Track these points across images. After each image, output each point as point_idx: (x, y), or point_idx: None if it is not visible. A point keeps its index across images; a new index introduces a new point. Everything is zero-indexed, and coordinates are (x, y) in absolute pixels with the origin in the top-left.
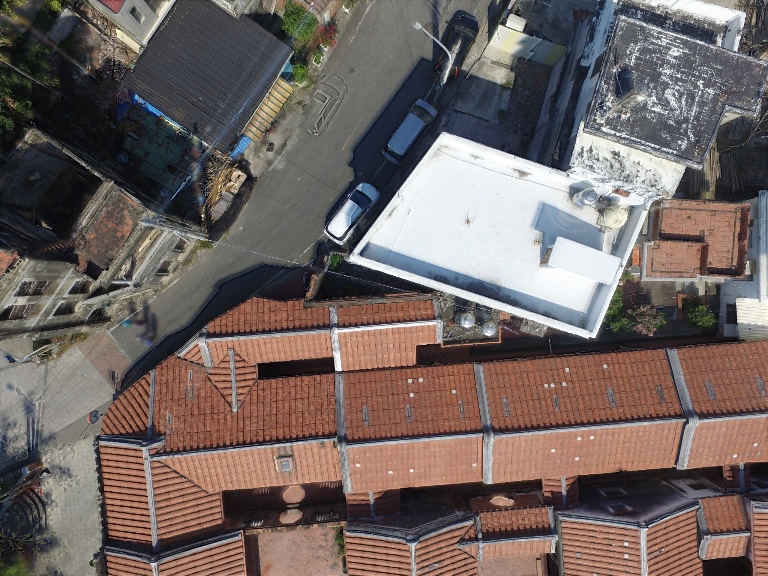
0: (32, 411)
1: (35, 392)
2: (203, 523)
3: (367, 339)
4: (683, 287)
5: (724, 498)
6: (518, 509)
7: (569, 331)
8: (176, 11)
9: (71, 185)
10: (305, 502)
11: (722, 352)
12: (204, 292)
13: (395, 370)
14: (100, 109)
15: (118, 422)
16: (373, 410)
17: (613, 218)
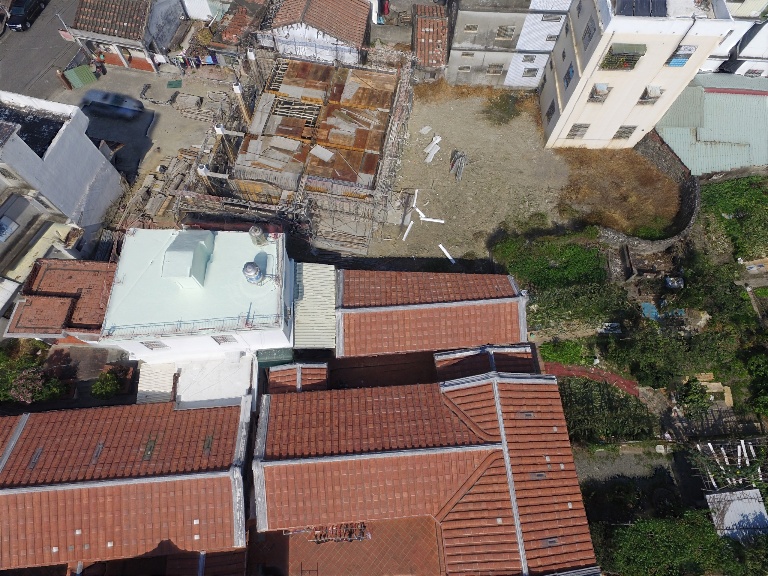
0: None
1: None
2: None
3: None
4: (120, 359)
5: None
6: None
7: None
8: None
9: None
10: None
11: (82, 416)
12: None
13: None
14: None
15: None
16: None
17: None
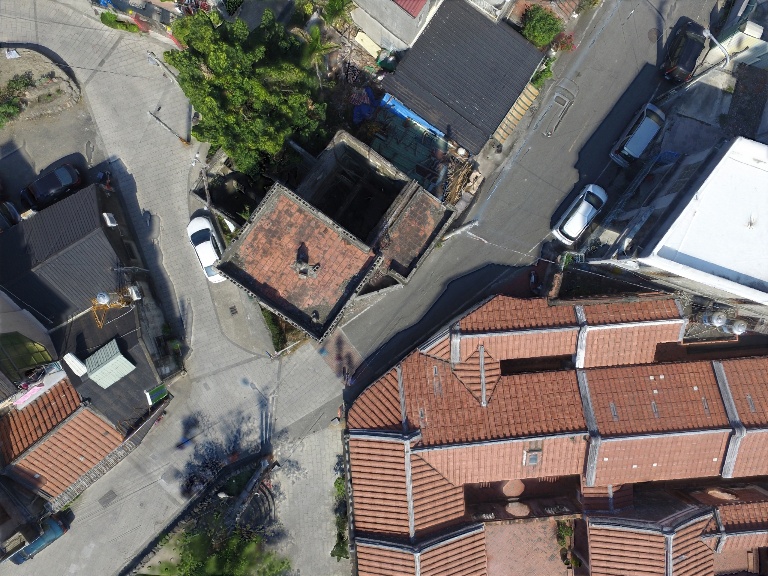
0: (266, 405)
1: (269, 387)
2: (449, 515)
3: (613, 337)
4: None
5: None
6: (754, 503)
7: None
8: (437, 15)
9: (334, 184)
10: (524, 495)
11: None
12: (433, 290)
13: (635, 367)
14: (336, 110)
15: (367, 416)
16: (620, 406)
17: None
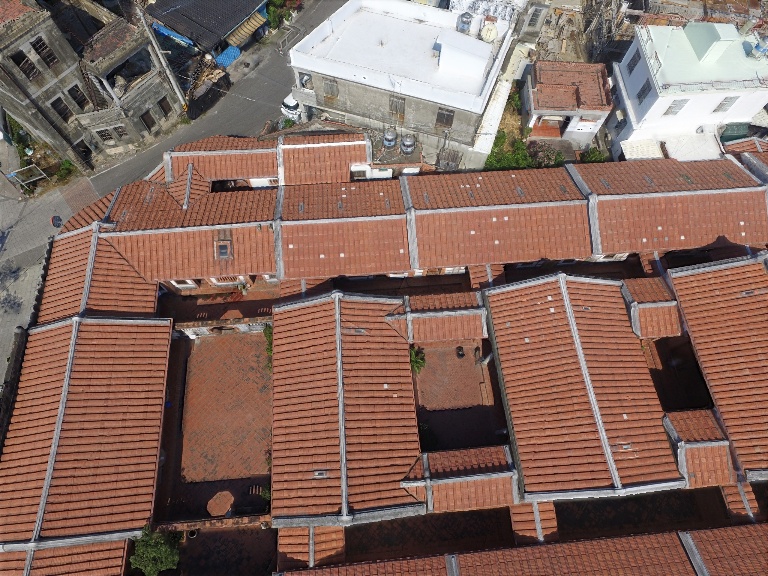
0: None
1: (8, 223)
2: (134, 307)
3: (307, 156)
4: (579, 149)
5: (645, 279)
6: (447, 293)
7: (465, 108)
8: None
9: None
10: None
11: (612, 165)
12: None
13: (331, 184)
14: None
15: (77, 223)
16: (309, 204)
17: (486, 29)
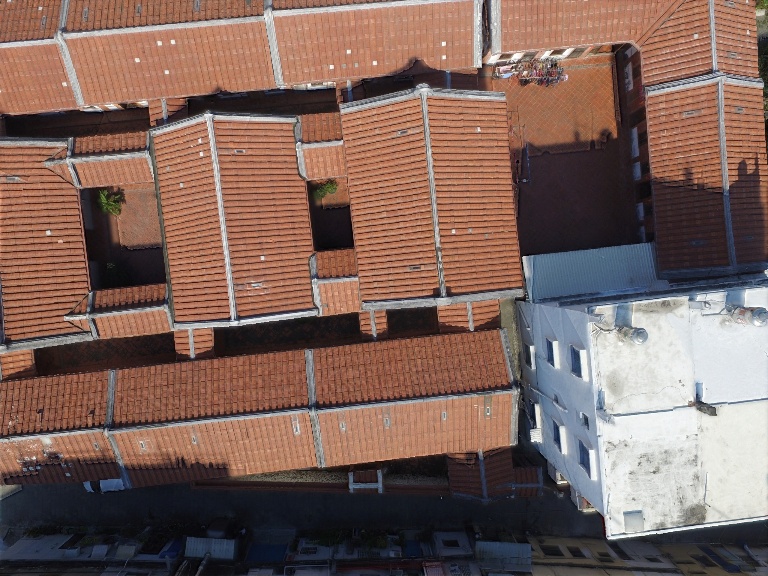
0: None
1: None
2: None
3: None
4: None
5: (325, 114)
6: (116, 134)
7: None
8: None
9: None
10: None
11: None
12: None
13: None
14: None
15: None
16: None
17: None
